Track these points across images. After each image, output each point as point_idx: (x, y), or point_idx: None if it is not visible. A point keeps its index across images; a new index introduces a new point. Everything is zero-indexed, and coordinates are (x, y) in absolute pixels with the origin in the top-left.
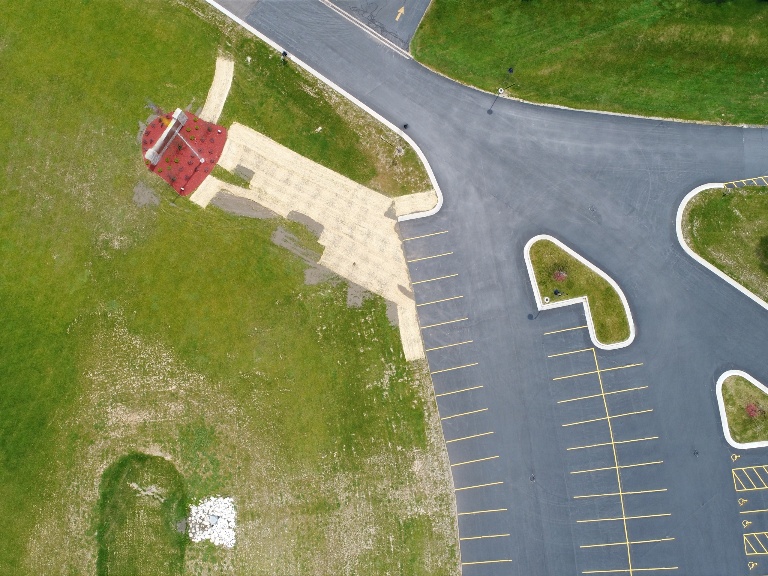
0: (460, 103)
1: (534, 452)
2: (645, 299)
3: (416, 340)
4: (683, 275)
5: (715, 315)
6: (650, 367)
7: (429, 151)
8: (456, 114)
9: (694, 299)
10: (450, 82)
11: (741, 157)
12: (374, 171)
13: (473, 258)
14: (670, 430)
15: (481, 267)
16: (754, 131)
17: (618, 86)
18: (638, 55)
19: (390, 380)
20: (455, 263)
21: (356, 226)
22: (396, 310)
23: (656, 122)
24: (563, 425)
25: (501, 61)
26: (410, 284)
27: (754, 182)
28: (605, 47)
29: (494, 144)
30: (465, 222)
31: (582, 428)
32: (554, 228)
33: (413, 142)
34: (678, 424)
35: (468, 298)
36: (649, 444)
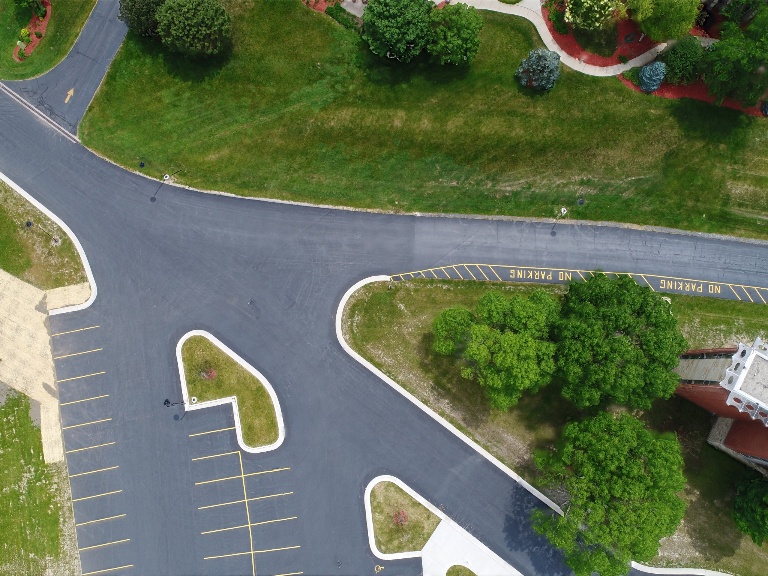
0: (123, 190)
1: (170, 561)
2: (297, 399)
3: (56, 441)
4: (339, 374)
5: (370, 417)
6: (297, 472)
7: (87, 241)
8: (118, 202)
9: (349, 399)
10: (115, 168)
11: (411, 248)
12: (29, 262)
13: (123, 354)
14: (313, 539)
15: (130, 364)
16: (427, 220)
17: (288, 172)
18: (308, 140)
19: (28, 483)
20: (104, 360)
21: (6, 320)
22: (39, 409)
23: (324, 211)
24: (202, 533)
25: (169, 146)
26: (55, 382)
27: (422, 275)
28: (274, 132)
29: (155, 234)
30: (118, 316)
31: (221, 536)
32: (210, 323)
33: (71, 231)
34: (322, 532)
35: (114, 397)
36: (290, 554)
